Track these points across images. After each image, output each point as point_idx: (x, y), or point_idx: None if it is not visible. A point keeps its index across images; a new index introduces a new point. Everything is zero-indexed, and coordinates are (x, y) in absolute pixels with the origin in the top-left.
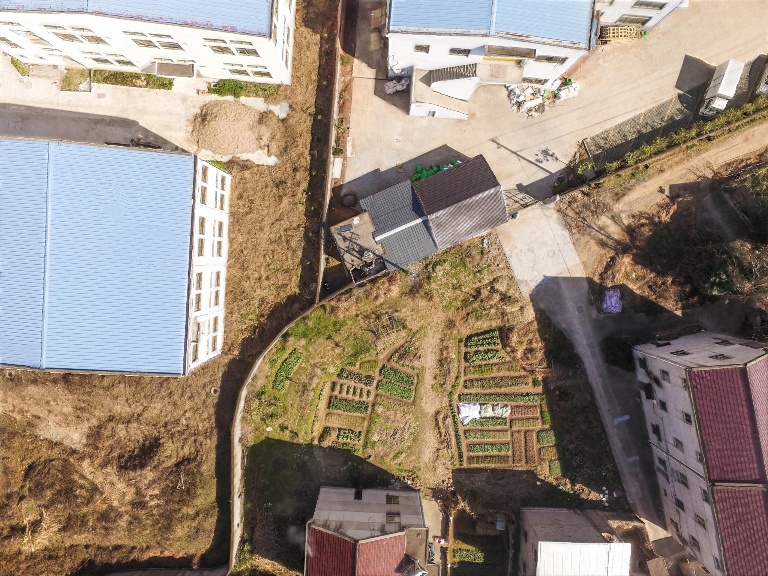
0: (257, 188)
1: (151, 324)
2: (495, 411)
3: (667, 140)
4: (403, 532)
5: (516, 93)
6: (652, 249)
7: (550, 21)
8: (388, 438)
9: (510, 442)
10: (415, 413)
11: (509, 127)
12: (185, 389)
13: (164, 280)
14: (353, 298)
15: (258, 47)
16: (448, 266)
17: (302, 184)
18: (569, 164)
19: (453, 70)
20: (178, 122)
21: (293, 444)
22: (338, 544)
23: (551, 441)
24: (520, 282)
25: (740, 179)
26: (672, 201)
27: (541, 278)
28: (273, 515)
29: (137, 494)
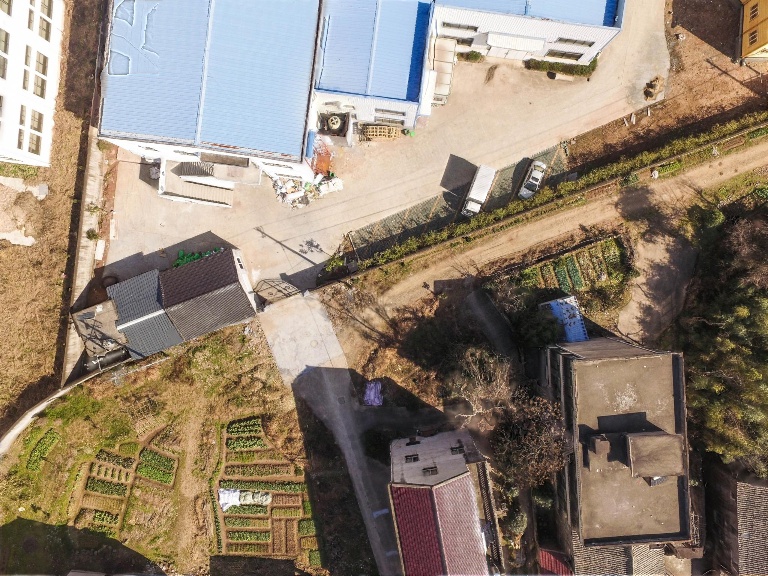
0: (13, 267)
1: None
2: (254, 499)
3: (420, 240)
4: None
5: (278, 185)
6: (417, 343)
7: (258, 133)
8: (146, 522)
9: (271, 530)
10: (174, 497)
11: (274, 217)
12: None
13: None
14: (109, 381)
15: None
16: (208, 352)
17: (58, 266)
18: (334, 256)
19: (198, 165)
20: None
21: (46, 525)
22: None
23: (311, 531)
24: (282, 371)
25: (500, 279)
26: (435, 297)
27: (303, 368)
28: None
29: None
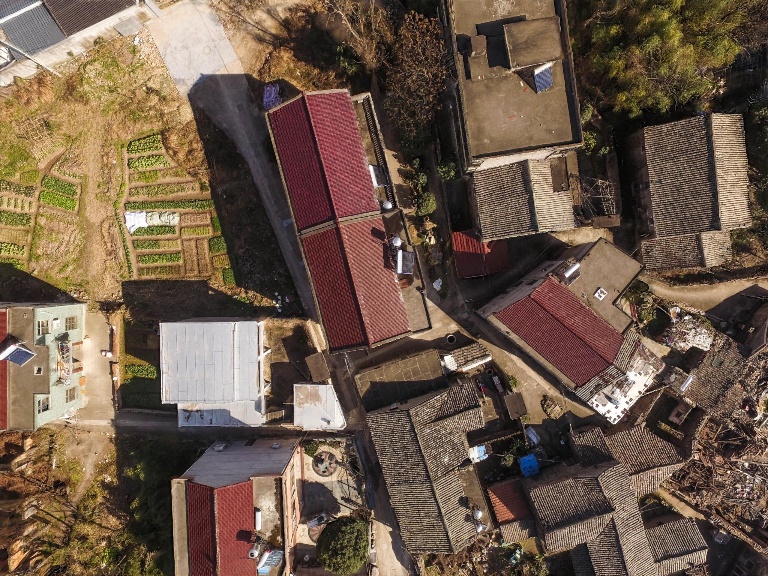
0: None
1: None
2: (161, 218)
3: None
4: (3, 309)
5: None
6: (314, 44)
7: None
8: (53, 251)
9: (181, 252)
10: (80, 224)
11: None
12: None
13: None
14: (0, 101)
15: None
16: (100, 66)
17: None
18: None
19: None
20: None
21: None
22: None
23: (222, 248)
24: (177, 81)
25: None
26: None
27: (198, 76)
28: None
29: None
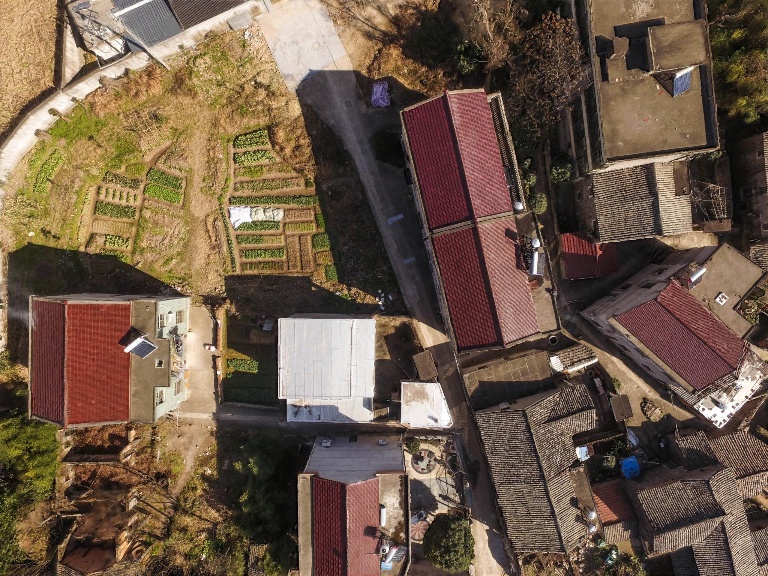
0: None
1: None
2: (266, 213)
3: None
4: (127, 302)
5: None
6: (422, 42)
7: None
8: (157, 244)
9: (284, 247)
10: (185, 218)
11: None
12: None
13: None
14: (110, 93)
15: None
16: (209, 60)
17: None
18: None
19: None
20: None
21: (57, 250)
22: (53, 310)
23: (326, 245)
24: (285, 77)
25: None
26: None
27: (307, 72)
28: None
29: None
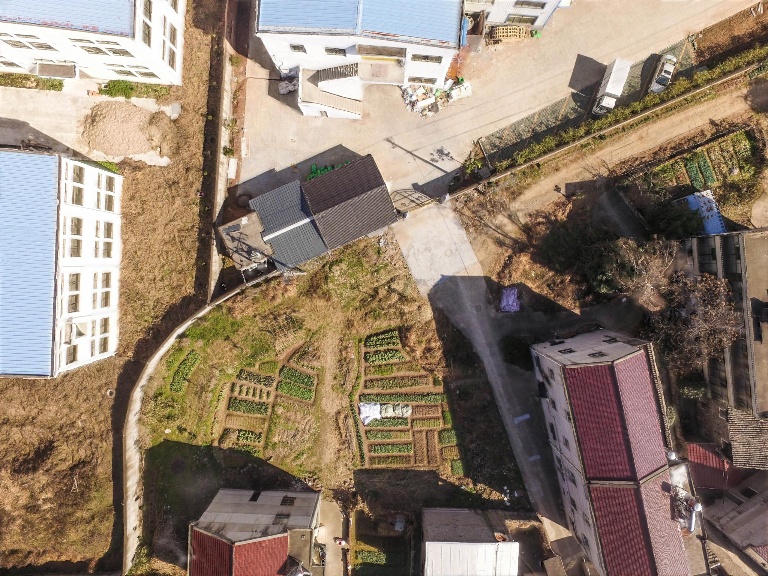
0: (150, 189)
1: (17, 325)
2: (395, 411)
3: (557, 139)
4: (285, 533)
5: (409, 93)
6: (550, 248)
7: (418, 20)
8: (289, 439)
9: (412, 442)
10: (316, 414)
11: (404, 127)
12: (80, 391)
13: (29, 281)
14: (249, 299)
15: (127, 47)
16: (345, 266)
17: (195, 185)
18: (464, 163)
19: (338, 70)
20: (69, 123)
21: (192, 446)
22: (217, 546)
23: (452, 441)
24: (418, 281)
25: (633, 177)
26: (568, 200)
27: (439, 277)
28: (172, 518)
29: (31, 498)
